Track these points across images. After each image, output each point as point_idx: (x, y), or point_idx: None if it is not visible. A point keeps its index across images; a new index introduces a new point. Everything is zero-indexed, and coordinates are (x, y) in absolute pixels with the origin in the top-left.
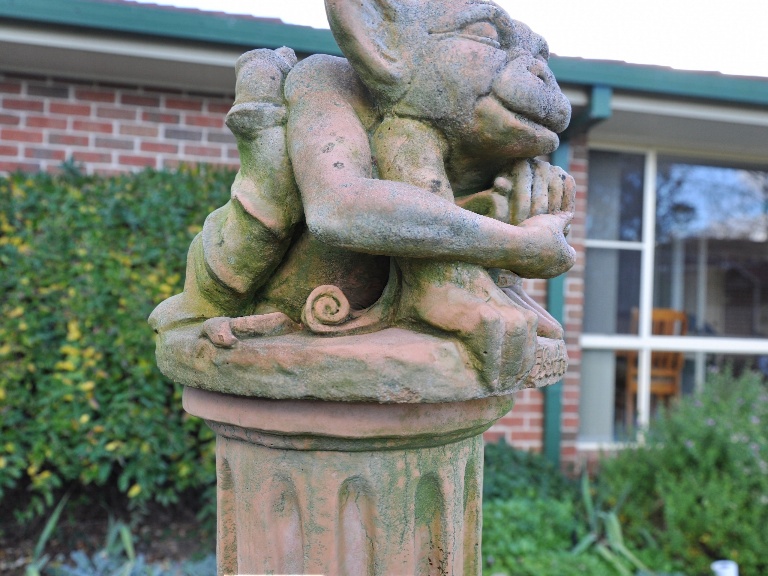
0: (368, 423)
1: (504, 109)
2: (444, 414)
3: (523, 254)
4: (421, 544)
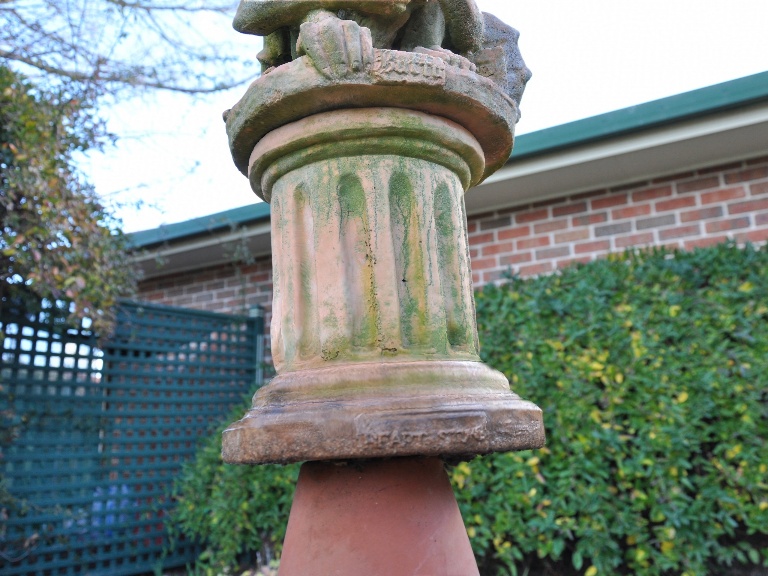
0: (287, 135)
1: None
2: (333, 119)
3: None
4: (357, 231)
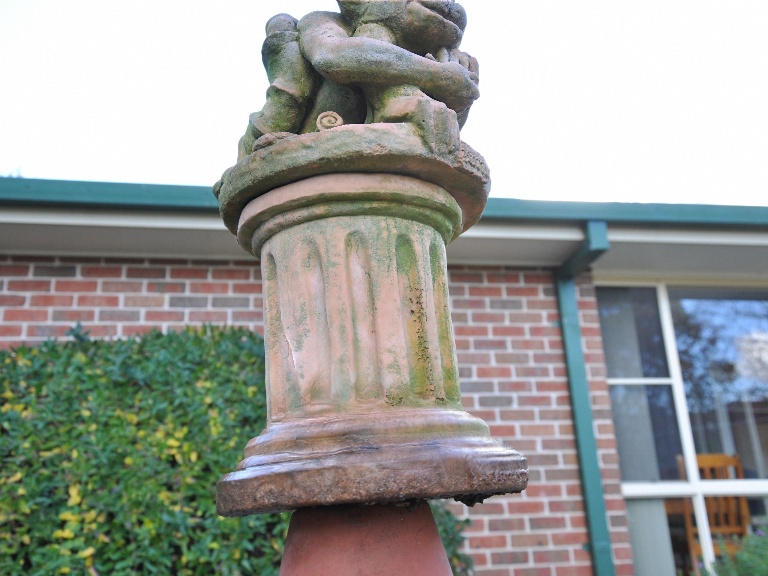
0: (359, 184)
1: (423, 7)
2: (407, 184)
3: (442, 76)
4: (403, 287)
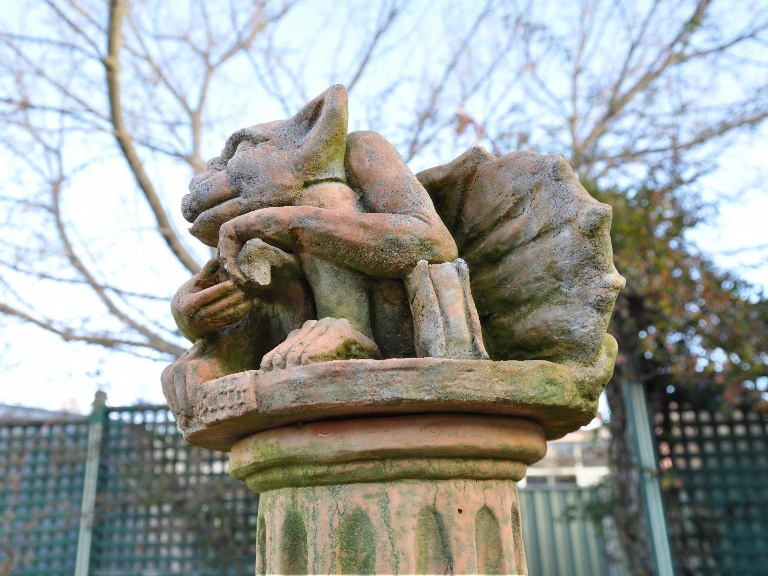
0: None
1: None
2: None
3: None
4: None
